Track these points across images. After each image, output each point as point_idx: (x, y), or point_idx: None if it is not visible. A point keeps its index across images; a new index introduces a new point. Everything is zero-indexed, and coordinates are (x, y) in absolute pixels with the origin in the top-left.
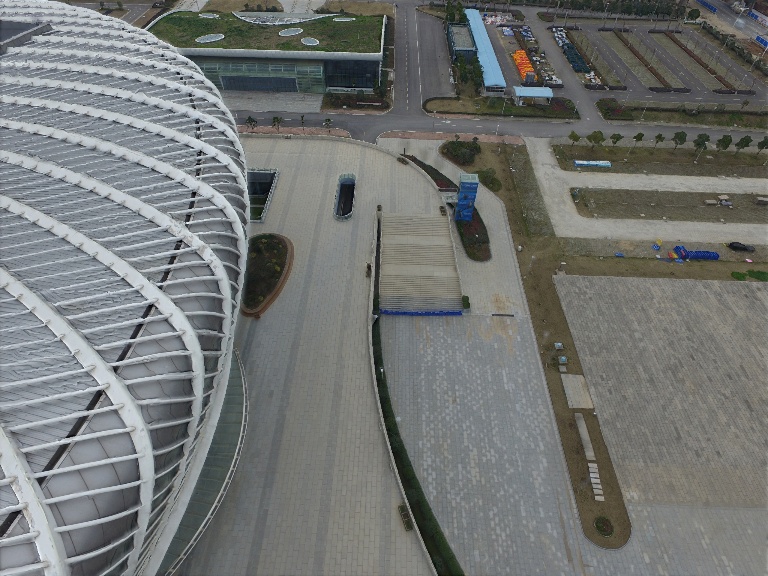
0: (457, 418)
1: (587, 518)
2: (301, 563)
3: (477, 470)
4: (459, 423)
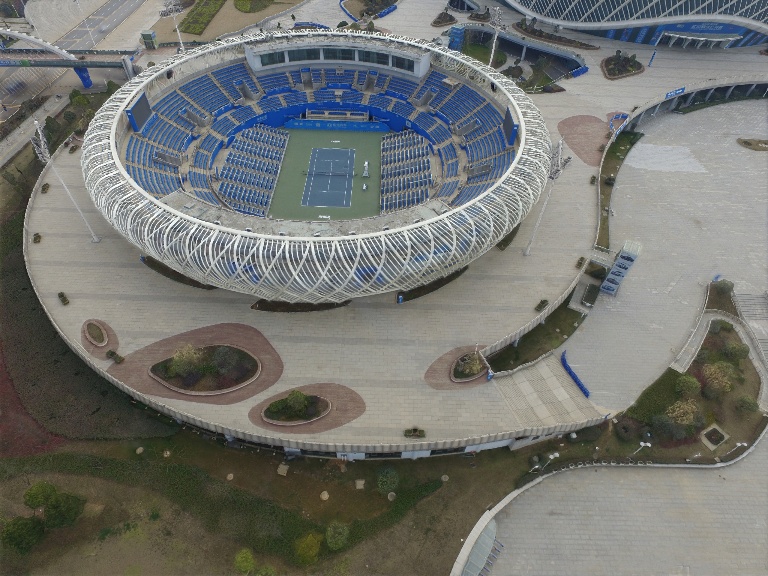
0: (763, 115)
1: (747, 140)
2: (678, 65)
3: (742, 117)
4: (761, 115)
